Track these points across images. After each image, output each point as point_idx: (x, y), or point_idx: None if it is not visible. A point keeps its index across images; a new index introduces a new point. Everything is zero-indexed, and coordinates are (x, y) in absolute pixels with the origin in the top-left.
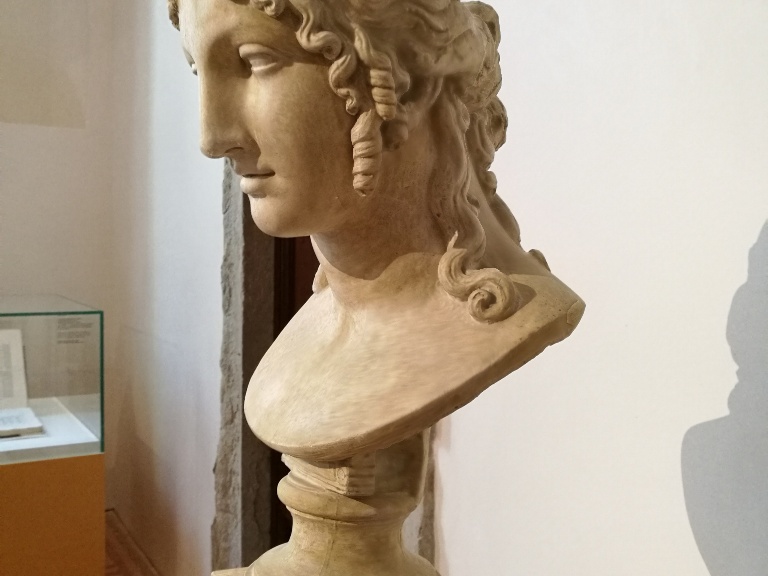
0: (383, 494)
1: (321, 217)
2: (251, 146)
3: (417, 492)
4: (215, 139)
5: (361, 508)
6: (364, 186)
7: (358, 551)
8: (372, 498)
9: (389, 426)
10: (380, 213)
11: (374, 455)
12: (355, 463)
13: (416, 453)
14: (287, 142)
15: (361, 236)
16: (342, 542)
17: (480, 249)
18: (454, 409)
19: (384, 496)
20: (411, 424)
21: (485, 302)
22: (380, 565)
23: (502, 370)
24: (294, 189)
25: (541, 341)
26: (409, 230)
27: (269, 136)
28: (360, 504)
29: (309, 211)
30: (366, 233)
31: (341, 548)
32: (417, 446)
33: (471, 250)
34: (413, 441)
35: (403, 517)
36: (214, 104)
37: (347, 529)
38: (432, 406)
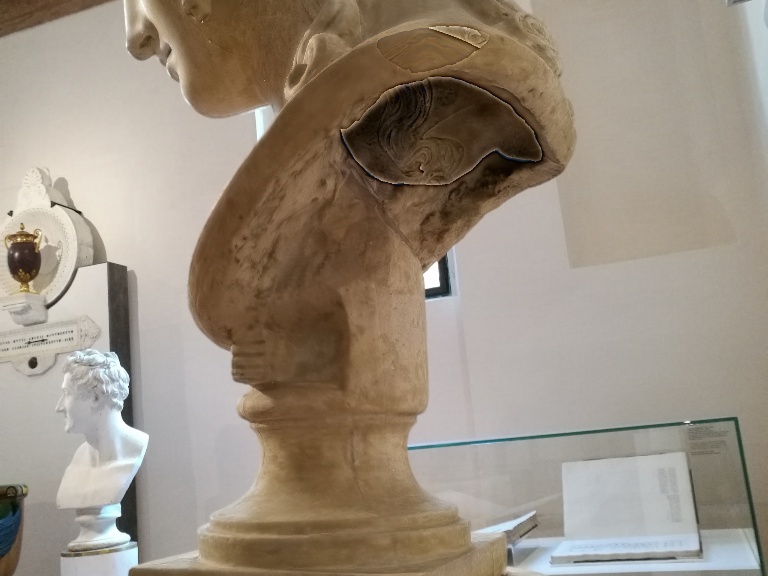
0: (293, 384)
1: (212, 71)
2: (153, 30)
3: (347, 384)
4: (127, 37)
5: (259, 400)
6: (184, 6)
7: (279, 464)
8: (277, 388)
9: (193, 264)
10: (264, 41)
11: (260, 327)
12: (237, 338)
13: (343, 330)
14: (148, 4)
15: (265, 79)
16: (268, 453)
17: (333, 23)
18: (241, 221)
19: (292, 386)
20: (207, 254)
21: (294, 77)
22: (301, 484)
23: (279, 149)
24: (177, 51)
25: (330, 92)
26: (288, 45)
27: (145, 9)
28: (261, 395)
29: (196, 69)
30: (265, 73)
31: (268, 461)
32: (342, 319)
33: (316, 28)
34: (336, 313)
35: (338, 421)
36: (126, 7)
37: (266, 434)
38: (211, 222)
